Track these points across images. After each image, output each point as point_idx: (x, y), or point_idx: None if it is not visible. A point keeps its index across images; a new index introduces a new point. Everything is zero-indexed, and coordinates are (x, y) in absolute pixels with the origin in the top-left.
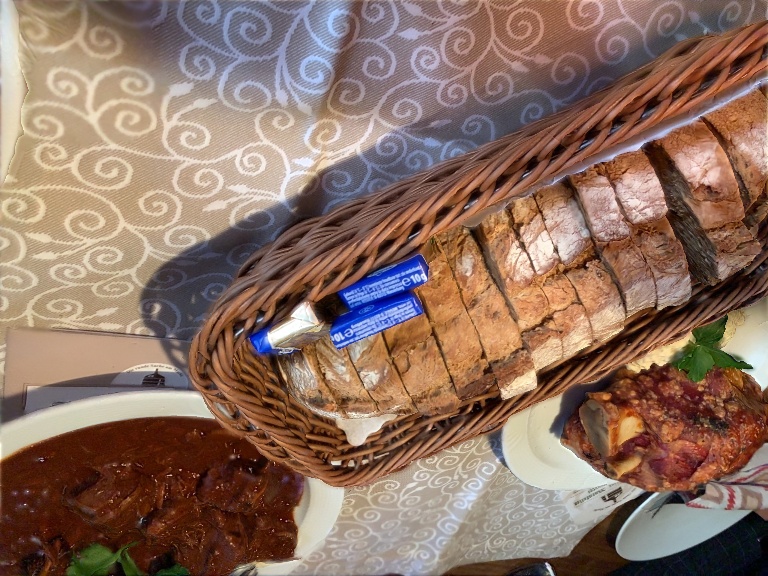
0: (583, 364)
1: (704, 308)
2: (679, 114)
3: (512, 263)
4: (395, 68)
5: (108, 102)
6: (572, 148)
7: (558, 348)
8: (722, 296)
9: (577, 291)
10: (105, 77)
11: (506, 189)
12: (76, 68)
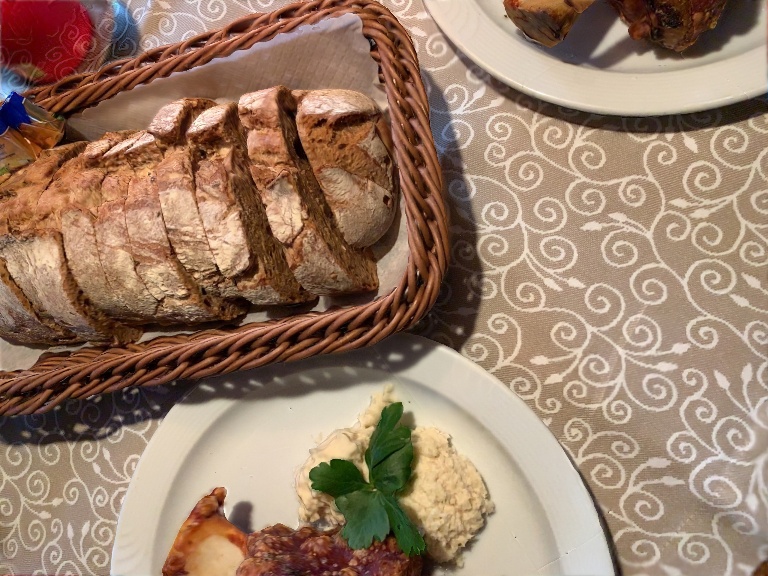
0: None
1: None
2: (231, 48)
3: None
4: None
5: (12, 68)
6: (156, 63)
7: (90, 238)
8: None
9: None
10: (16, 54)
11: (105, 81)
12: (8, 47)
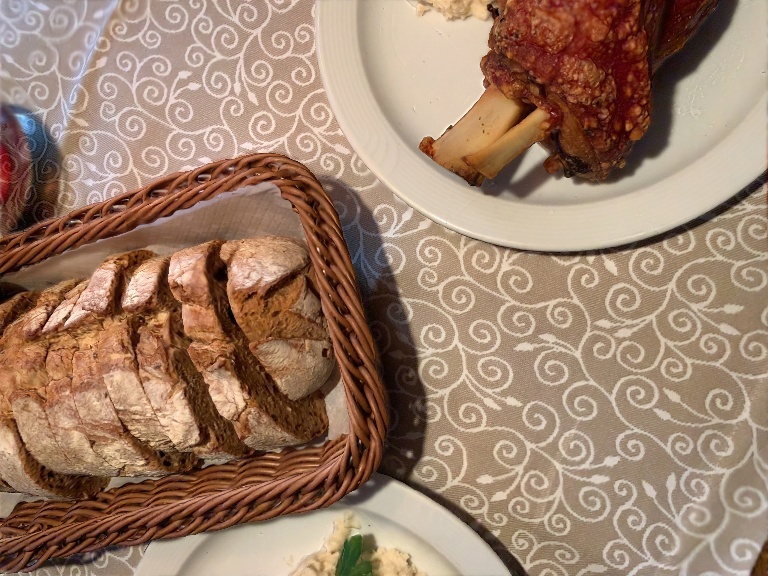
0: (128, 512)
1: (254, 485)
2: (153, 213)
3: (32, 317)
4: (78, 202)
5: None
6: (80, 226)
7: (43, 422)
8: (279, 479)
9: None
10: None
11: (31, 246)
12: None
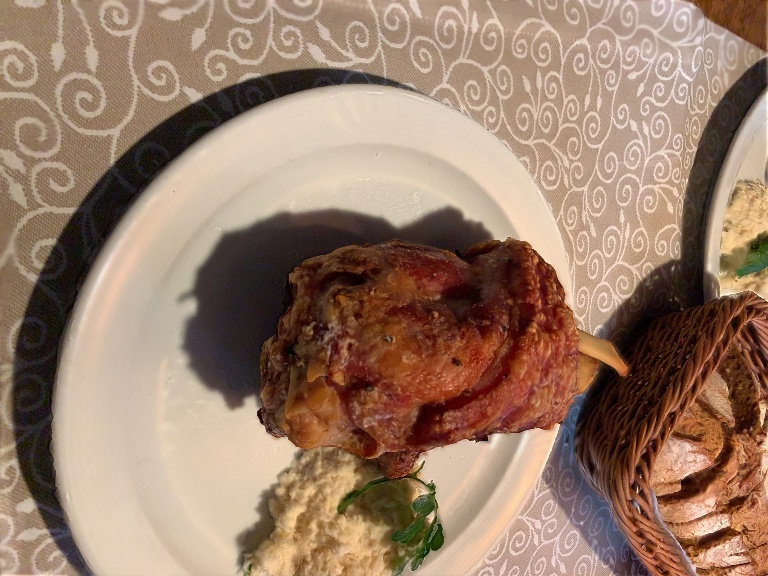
0: None
1: None
2: None
3: (741, 575)
4: None
5: None
6: None
7: None
8: (763, 348)
9: (763, 525)
10: None
11: None
12: None
